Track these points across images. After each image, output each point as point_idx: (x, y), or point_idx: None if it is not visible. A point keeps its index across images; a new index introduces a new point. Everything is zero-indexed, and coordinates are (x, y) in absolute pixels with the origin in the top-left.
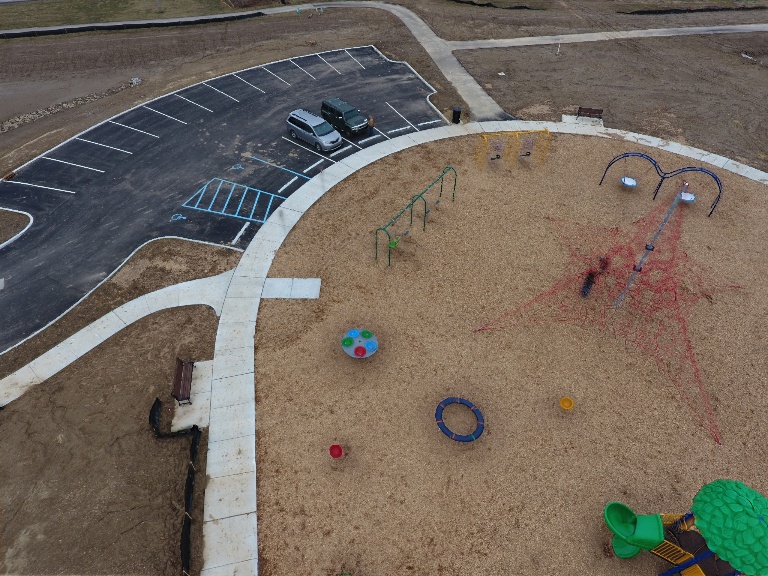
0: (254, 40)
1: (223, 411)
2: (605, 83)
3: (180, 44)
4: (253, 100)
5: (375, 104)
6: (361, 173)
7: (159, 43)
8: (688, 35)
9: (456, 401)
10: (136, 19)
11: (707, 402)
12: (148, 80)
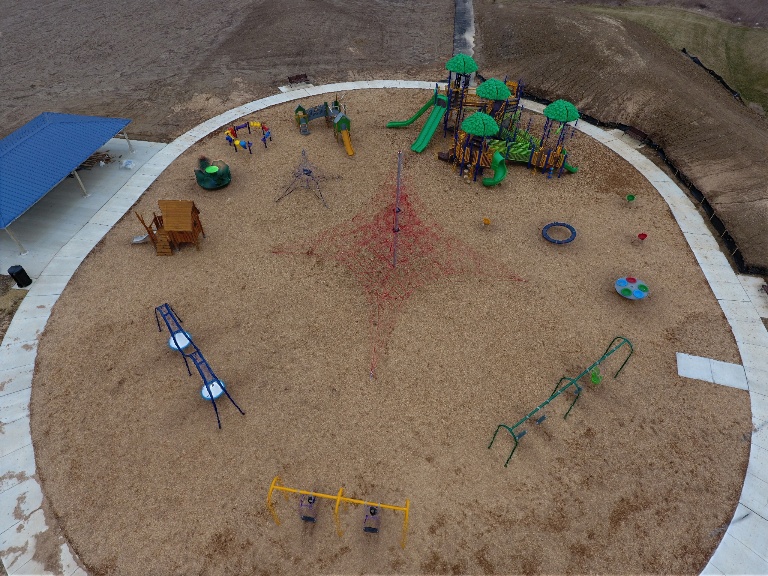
0: None
1: (730, 280)
2: None
3: None
4: None
5: None
6: None
7: None
8: None
9: None
10: None
11: None
12: None
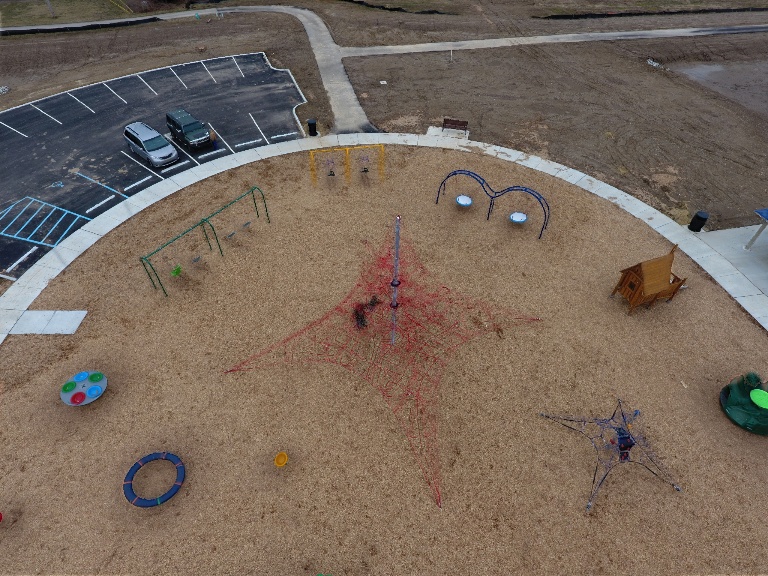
0: (143, 46)
1: None
2: (488, 92)
3: (63, 51)
4: (110, 111)
5: (237, 115)
6: (186, 191)
7: (41, 50)
8: (597, 41)
9: (160, 457)
10: (25, 25)
11: (446, 456)
12: (16, 89)
